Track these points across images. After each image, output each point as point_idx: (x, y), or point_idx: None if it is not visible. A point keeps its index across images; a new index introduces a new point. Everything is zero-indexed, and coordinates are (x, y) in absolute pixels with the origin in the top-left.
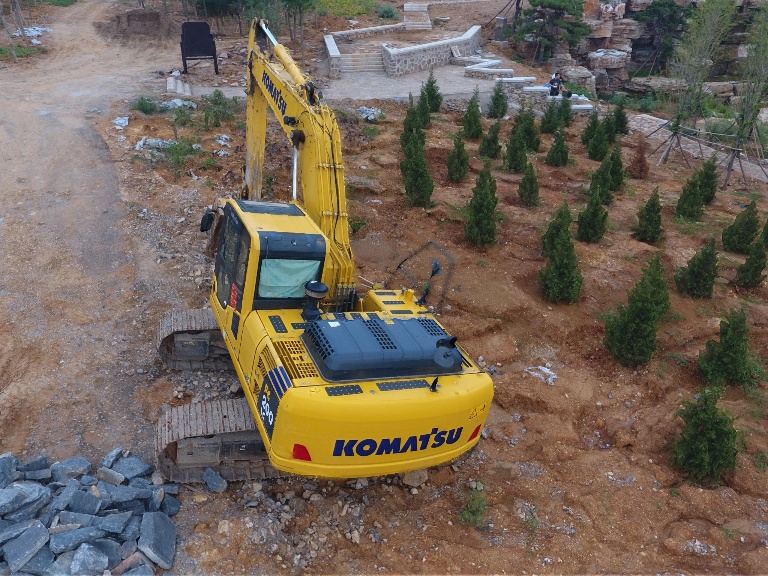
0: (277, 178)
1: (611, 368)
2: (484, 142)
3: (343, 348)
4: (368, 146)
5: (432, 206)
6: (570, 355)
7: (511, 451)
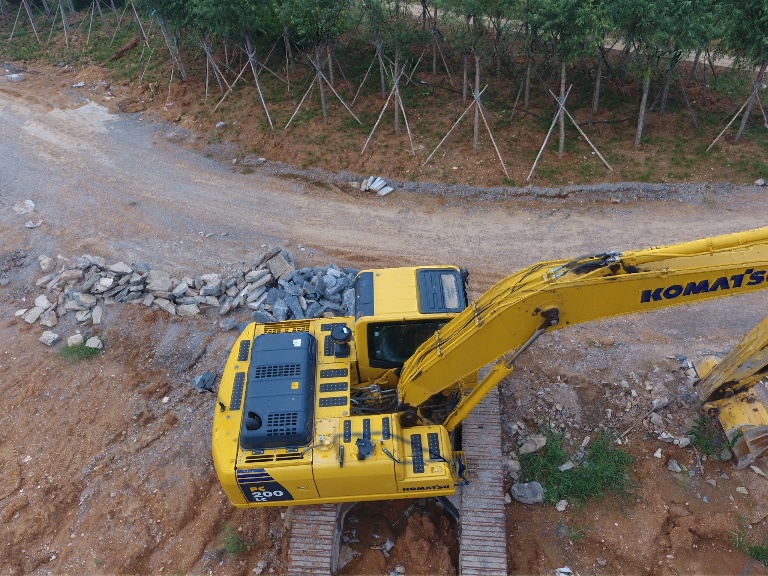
0: None
1: None
2: None
3: (265, 341)
4: None
5: None
6: None
7: None
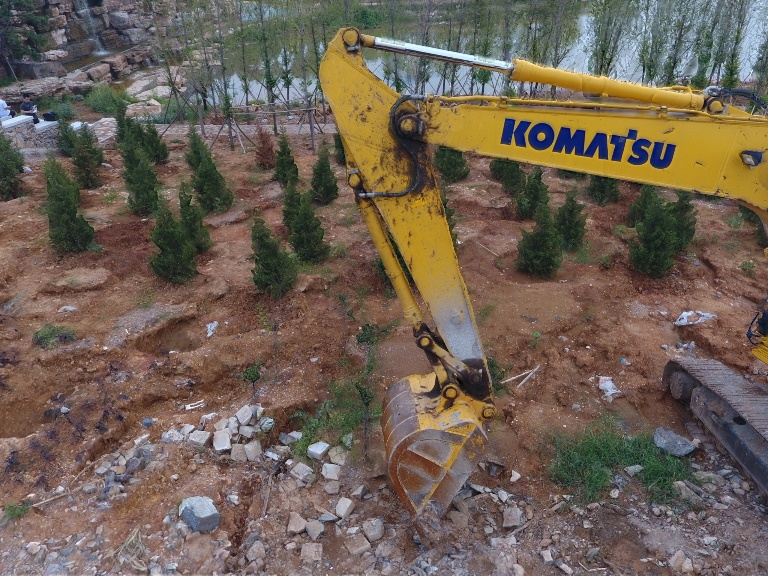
0: (2, 416)
1: (663, 285)
2: (140, 195)
3: None
4: (1, 281)
5: (295, 281)
6: (642, 298)
7: None
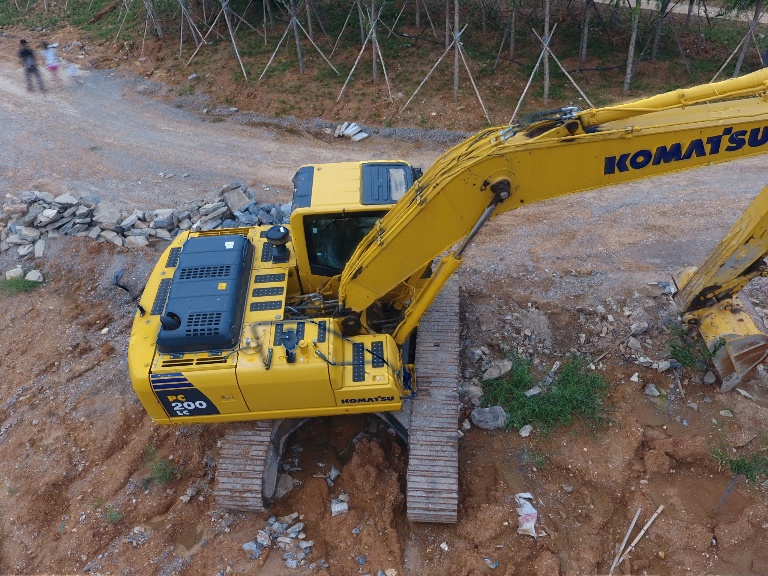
0: None
1: None
2: None
3: (194, 243)
4: None
5: None
6: None
7: (214, 570)
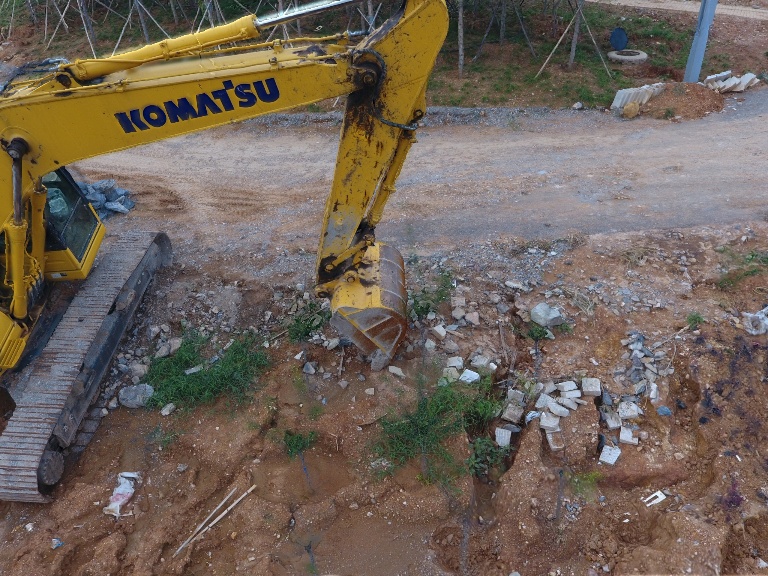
0: None
1: None
2: None
3: None
4: None
5: None
6: None
7: None
